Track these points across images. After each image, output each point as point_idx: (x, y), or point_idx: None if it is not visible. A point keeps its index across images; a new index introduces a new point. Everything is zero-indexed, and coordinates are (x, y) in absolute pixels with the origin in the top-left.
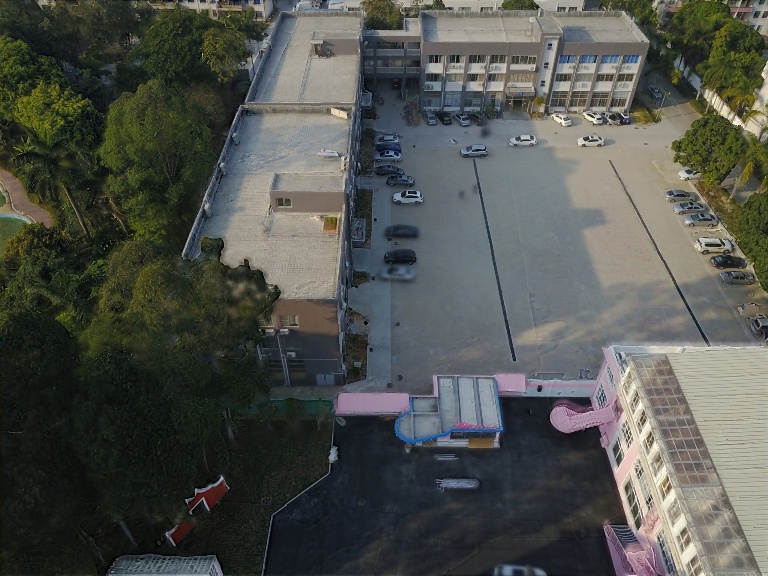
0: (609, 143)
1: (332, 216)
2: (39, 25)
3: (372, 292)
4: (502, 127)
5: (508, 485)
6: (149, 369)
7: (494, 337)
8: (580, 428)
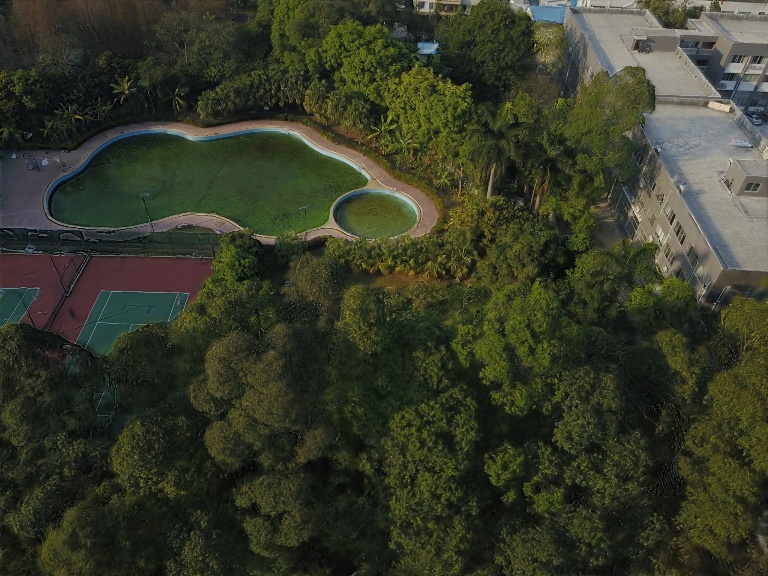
0: None
1: None
2: (363, 10)
3: None
4: None
5: None
6: None
7: None
8: None
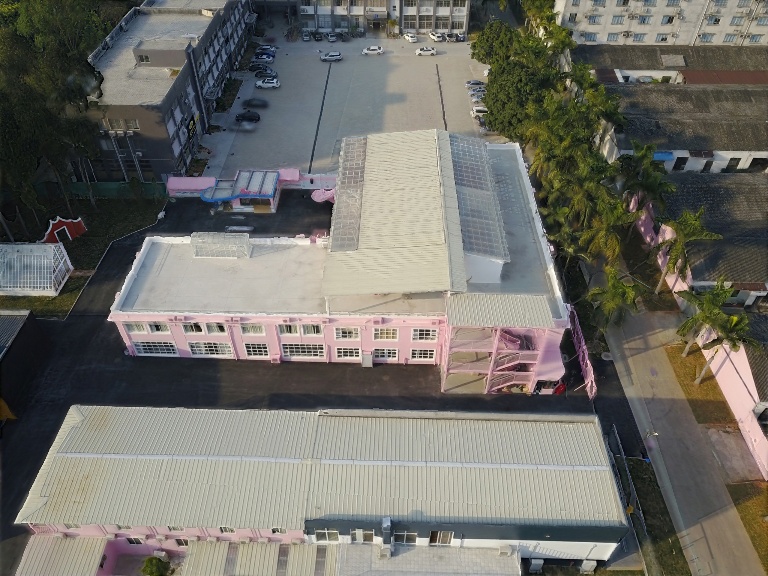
0: (441, 53)
1: (179, 69)
2: None
3: (221, 137)
4: (362, 43)
5: (273, 230)
6: (3, 92)
7: (300, 162)
8: (327, 198)
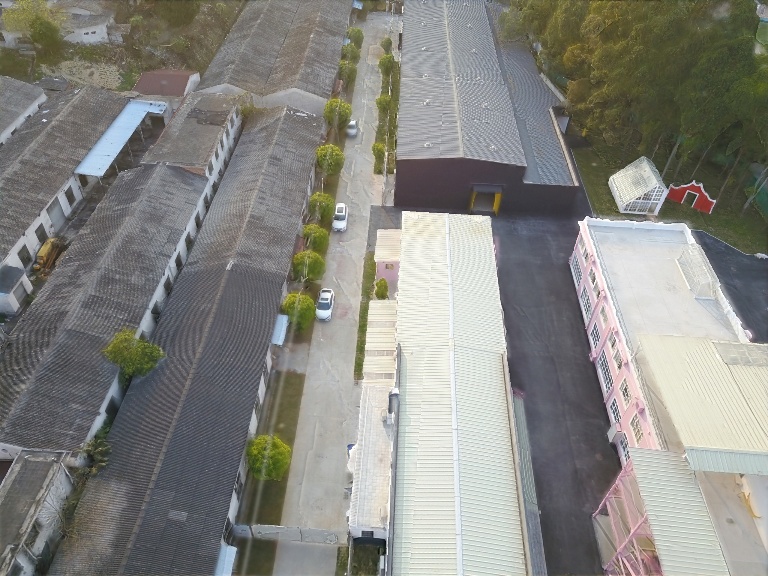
0: None
1: None
2: None
3: None
4: None
5: None
6: (756, 63)
7: None
8: None
